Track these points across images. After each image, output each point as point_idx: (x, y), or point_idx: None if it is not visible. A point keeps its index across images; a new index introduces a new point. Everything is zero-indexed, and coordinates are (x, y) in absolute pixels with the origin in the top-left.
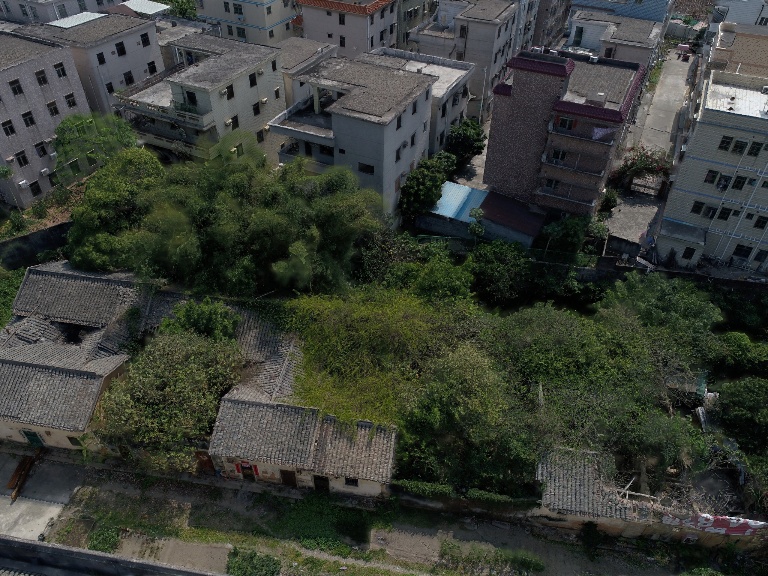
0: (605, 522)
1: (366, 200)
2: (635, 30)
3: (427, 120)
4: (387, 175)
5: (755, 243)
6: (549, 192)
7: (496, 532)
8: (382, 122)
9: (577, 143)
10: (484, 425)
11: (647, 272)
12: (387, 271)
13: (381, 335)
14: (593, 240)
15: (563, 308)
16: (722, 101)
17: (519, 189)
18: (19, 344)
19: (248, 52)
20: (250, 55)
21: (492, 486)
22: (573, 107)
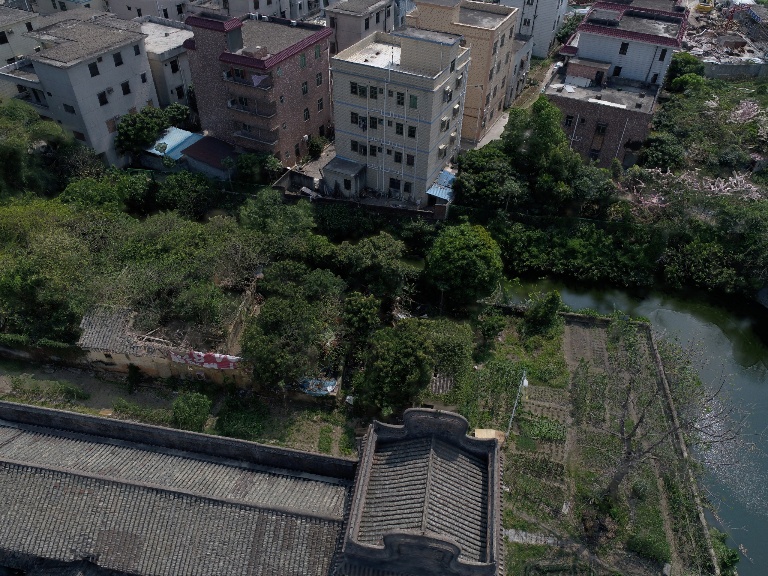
0: (141, 364)
1: (40, 129)
2: (361, 2)
3: (145, 73)
4: (89, 115)
5: (400, 176)
6: (246, 135)
7: (68, 375)
8: (63, 66)
9: (245, 89)
10: (51, 289)
11: (310, 199)
12: (64, 190)
13: (10, 229)
14: (272, 174)
15: (177, 214)
16: (368, 55)
17: (227, 133)
18: None
19: (6, 15)
20: (5, 17)
21: (60, 337)
22: (232, 57)
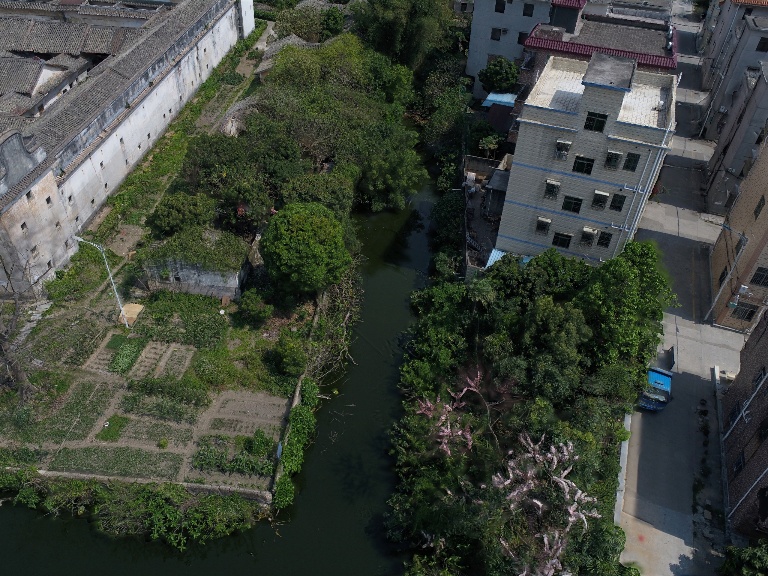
0: None
1: None
2: None
3: None
4: (477, 40)
5: None
6: None
7: None
8: None
9: None
10: None
11: None
12: None
13: None
14: None
15: None
16: None
17: None
18: (328, 7)
19: None
20: None
21: None
22: None
